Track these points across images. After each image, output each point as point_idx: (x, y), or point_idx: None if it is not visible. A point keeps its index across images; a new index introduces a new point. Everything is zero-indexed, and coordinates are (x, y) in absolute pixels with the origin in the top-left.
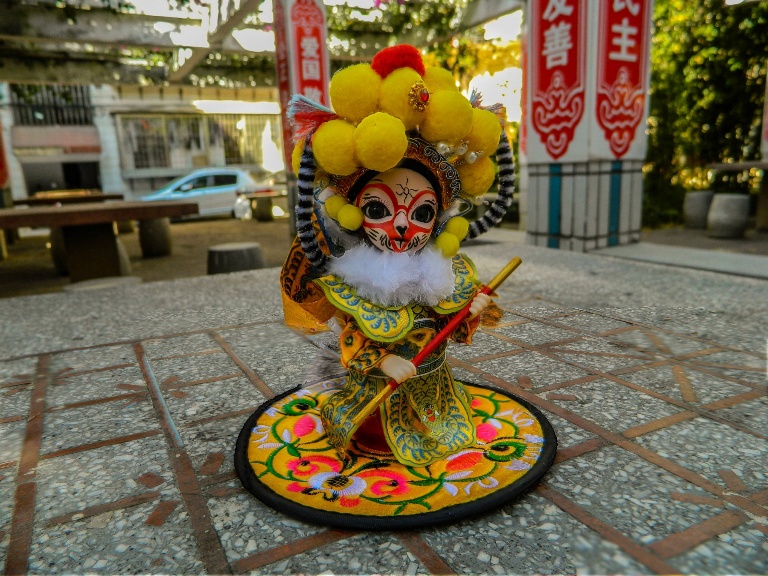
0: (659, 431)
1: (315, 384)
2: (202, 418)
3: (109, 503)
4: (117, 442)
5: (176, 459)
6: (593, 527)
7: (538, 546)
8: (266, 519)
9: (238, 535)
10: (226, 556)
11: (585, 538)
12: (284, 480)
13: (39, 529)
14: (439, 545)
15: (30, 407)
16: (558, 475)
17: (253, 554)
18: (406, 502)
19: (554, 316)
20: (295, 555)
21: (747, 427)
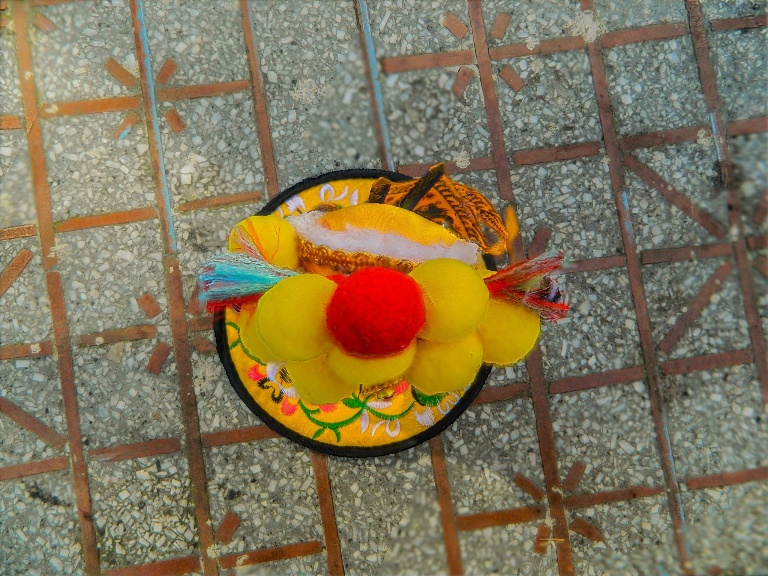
0: (584, 392)
1: (313, 189)
2: (196, 198)
3: (120, 330)
4: (118, 222)
5: (170, 276)
6: (438, 488)
7: (393, 491)
8: (230, 395)
9: (209, 406)
10: (199, 426)
11: (426, 496)
12: (248, 361)
13: (75, 348)
14: (333, 467)
15: (22, 93)
16: (457, 422)
17: (216, 431)
18: (326, 426)
19: (730, 22)
20: (241, 443)
21: (664, 413)
